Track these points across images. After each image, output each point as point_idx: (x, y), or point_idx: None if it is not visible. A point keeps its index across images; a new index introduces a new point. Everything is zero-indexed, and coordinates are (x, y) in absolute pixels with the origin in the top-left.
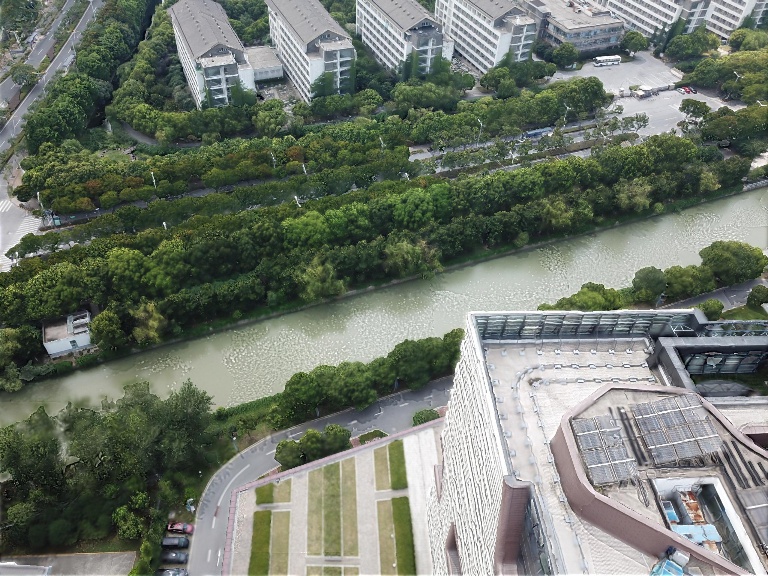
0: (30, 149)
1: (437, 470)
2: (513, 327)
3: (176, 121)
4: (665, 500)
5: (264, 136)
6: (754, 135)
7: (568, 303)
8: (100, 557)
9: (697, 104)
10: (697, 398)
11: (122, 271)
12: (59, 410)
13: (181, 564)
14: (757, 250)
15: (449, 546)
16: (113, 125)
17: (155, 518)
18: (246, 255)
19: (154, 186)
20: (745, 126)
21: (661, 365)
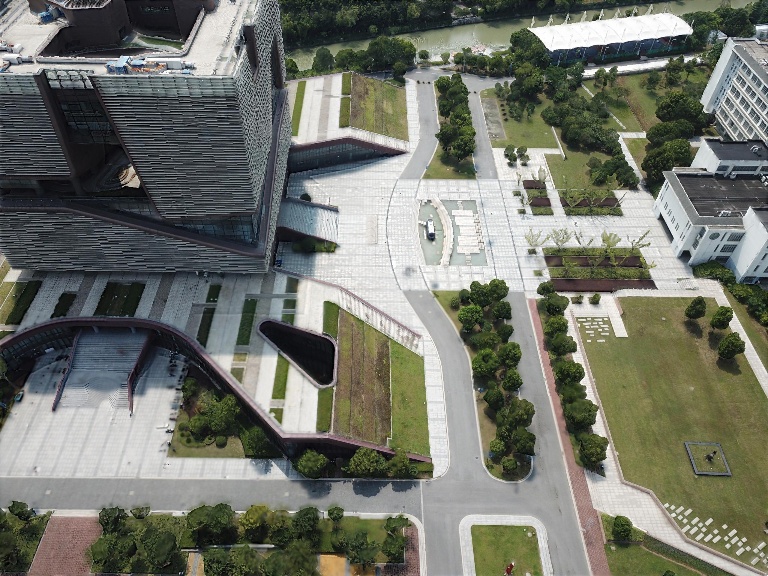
0: None
1: None
2: None
3: None
4: (63, 1)
5: None
6: None
7: None
8: None
9: None
10: None
11: None
12: None
13: None
14: (405, 42)
15: None
16: None
17: None
18: None
19: None
20: None
21: None
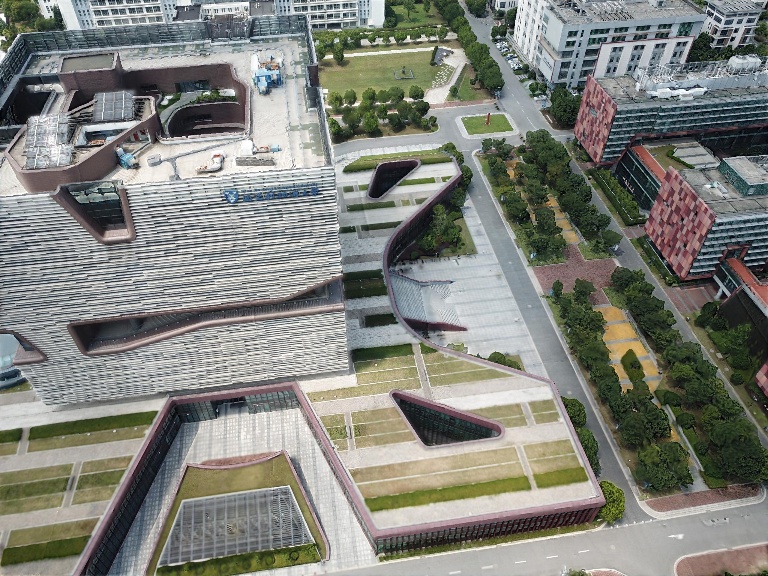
0: None
1: (18, 360)
2: None
3: None
4: None
5: None
6: None
7: None
8: None
9: None
10: (33, 117)
11: None
12: None
13: None
14: None
15: (84, 348)
16: None
17: None
18: None
19: None
20: None
21: None
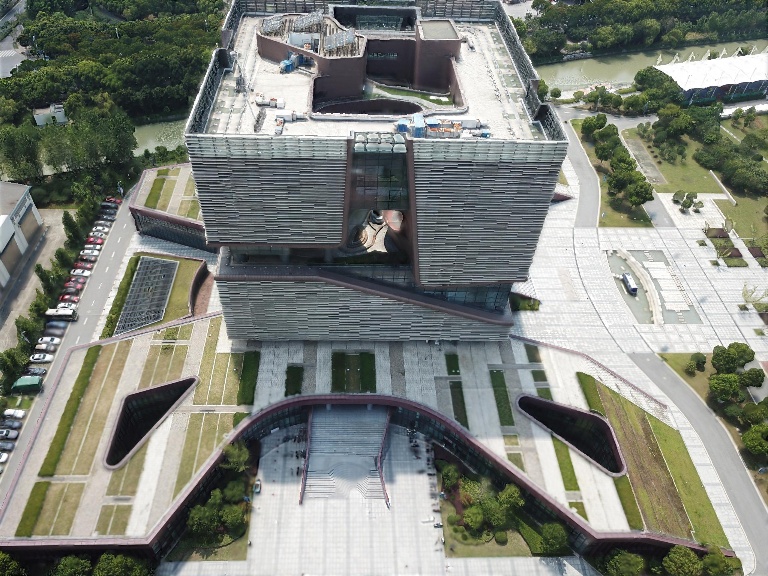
0: (30, 17)
1: None
2: (260, 4)
3: (139, 2)
4: None
5: (202, 12)
6: (585, 25)
7: None
8: (63, 211)
9: (543, 2)
10: None
11: (87, 73)
12: (40, 128)
13: (112, 215)
14: None
15: None
16: (93, 9)
17: (98, 194)
18: (175, 72)
19: (117, 38)
20: (572, 15)
21: None
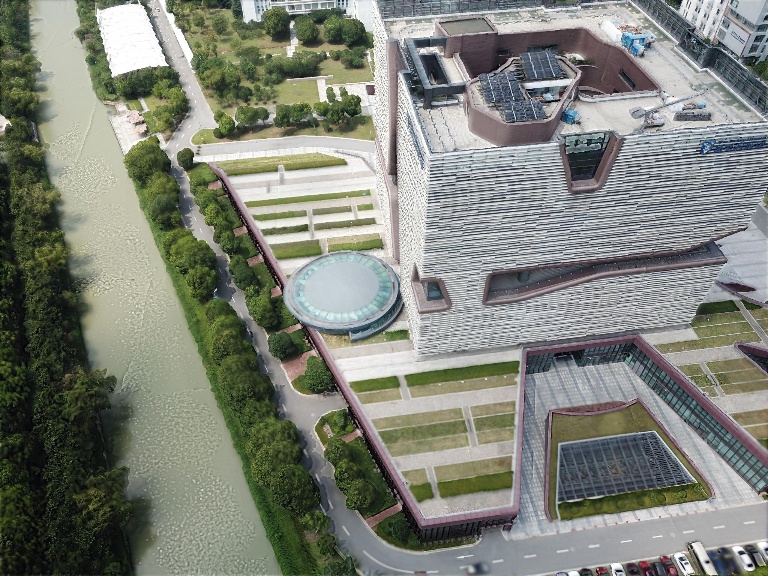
0: None
1: (425, 309)
2: None
3: None
4: None
5: None
6: None
7: (193, 257)
8: None
9: None
10: (483, 74)
11: None
12: None
13: None
14: (144, 142)
15: (486, 298)
16: None
17: None
18: None
19: None
20: None
21: (433, 101)
